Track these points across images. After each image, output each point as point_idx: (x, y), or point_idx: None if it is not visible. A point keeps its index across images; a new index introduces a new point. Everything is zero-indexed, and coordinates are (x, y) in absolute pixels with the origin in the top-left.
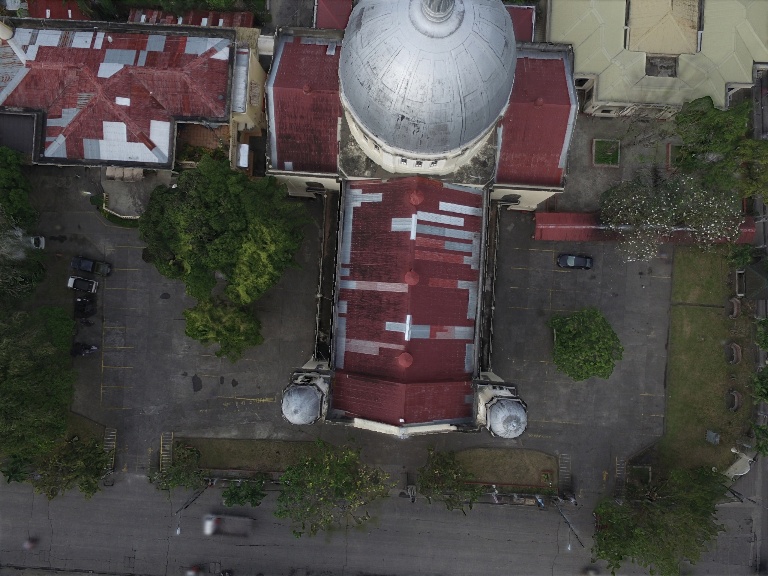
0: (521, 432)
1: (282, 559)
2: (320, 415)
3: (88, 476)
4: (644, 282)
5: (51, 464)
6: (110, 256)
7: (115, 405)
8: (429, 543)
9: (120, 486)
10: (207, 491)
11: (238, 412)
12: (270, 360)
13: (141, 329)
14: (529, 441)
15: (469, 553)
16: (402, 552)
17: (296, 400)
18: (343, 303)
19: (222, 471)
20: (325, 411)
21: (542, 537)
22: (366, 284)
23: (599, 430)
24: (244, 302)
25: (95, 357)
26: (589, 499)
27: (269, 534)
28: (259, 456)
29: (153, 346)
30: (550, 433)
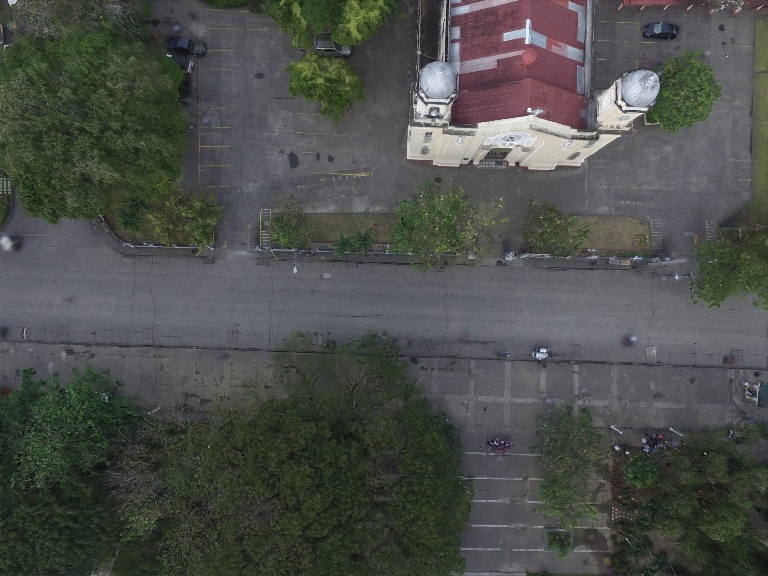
0: (656, 93)
1: (383, 329)
2: (455, 94)
3: (204, 219)
4: (727, 51)
5: (167, 208)
6: (203, 38)
7: (213, 184)
8: (527, 309)
9: (221, 263)
10: (307, 265)
11: (335, 187)
12: (365, 135)
13: (237, 109)
14: (621, 208)
15: (566, 318)
16: (501, 318)
17: (438, 64)
18: (456, 29)
19: (322, 244)
20: (449, 117)
21: (637, 300)
22: (480, 4)
23: (689, 195)
24: (355, 39)
25: (192, 137)
26: (681, 262)
27: (370, 305)
28: (357, 229)
29: (249, 125)
30: (641, 199)
